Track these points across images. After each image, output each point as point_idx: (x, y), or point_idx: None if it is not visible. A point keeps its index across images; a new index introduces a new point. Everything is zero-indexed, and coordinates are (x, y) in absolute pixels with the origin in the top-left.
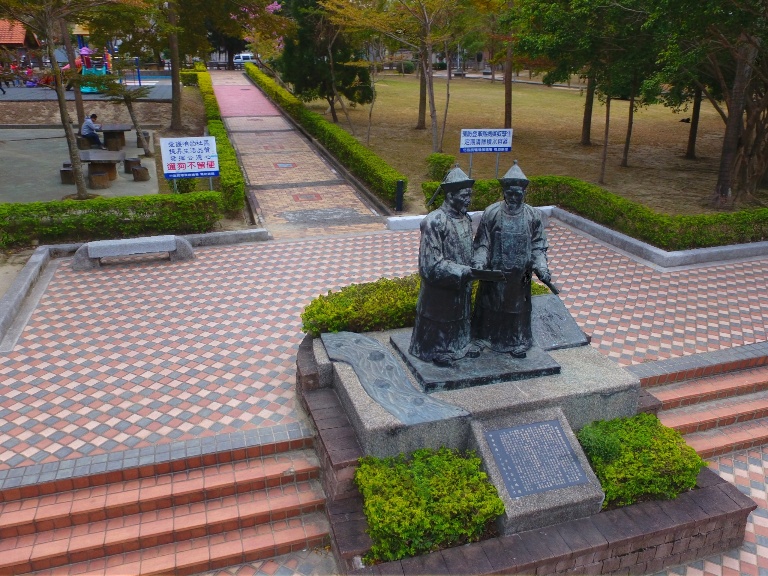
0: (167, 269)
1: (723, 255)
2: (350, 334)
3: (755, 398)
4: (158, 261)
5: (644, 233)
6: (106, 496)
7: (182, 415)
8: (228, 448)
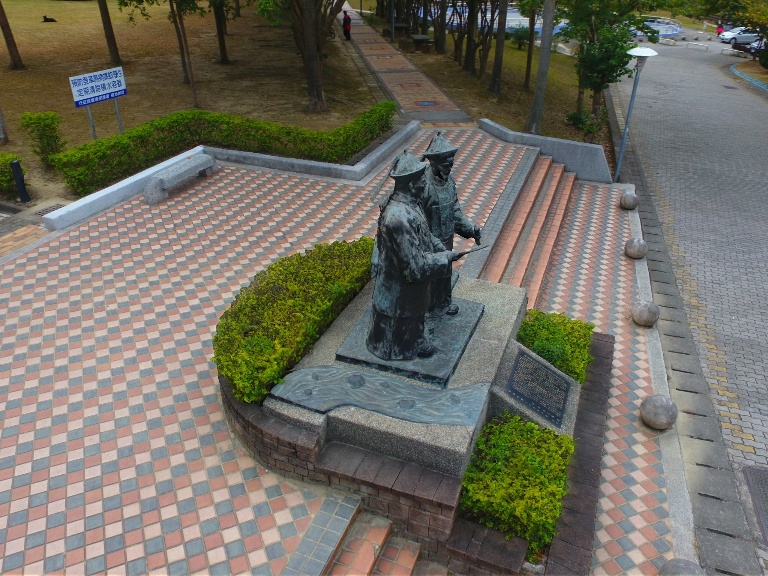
0: None
1: (383, 156)
2: (297, 375)
3: (515, 264)
4: None
5: (312, 153)
6: None
7: None
8: None
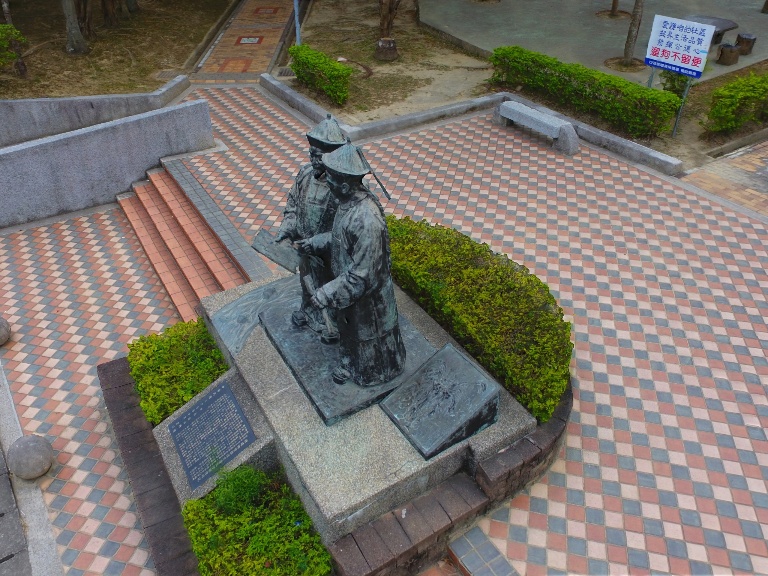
0: (531, 152)
1: None
2: None
3: None
4: (545, 143)
5: None
6: (203, 240)
7: None
8: (242, 264)
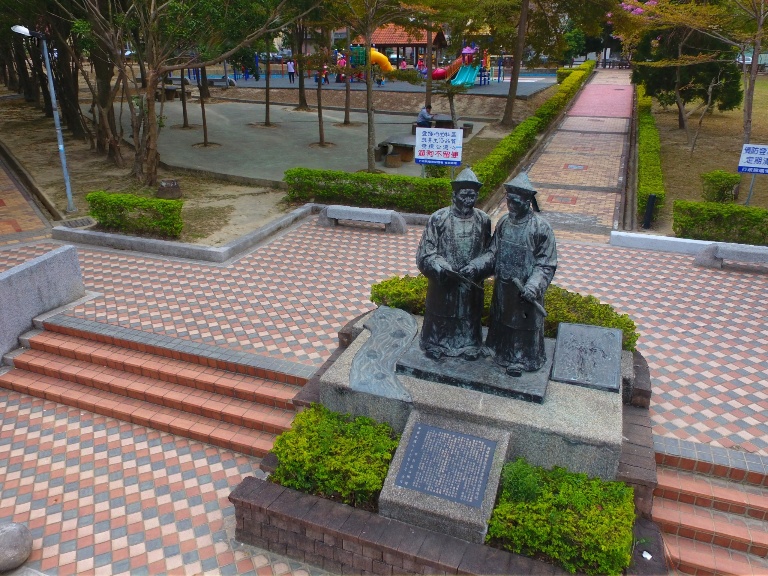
0: (376, 237)
1: None
2: (402, 312)
3: None
4: (377, 230)
5: None
6: (183, 369)
7: (265, 337)
8: (264, 367)
